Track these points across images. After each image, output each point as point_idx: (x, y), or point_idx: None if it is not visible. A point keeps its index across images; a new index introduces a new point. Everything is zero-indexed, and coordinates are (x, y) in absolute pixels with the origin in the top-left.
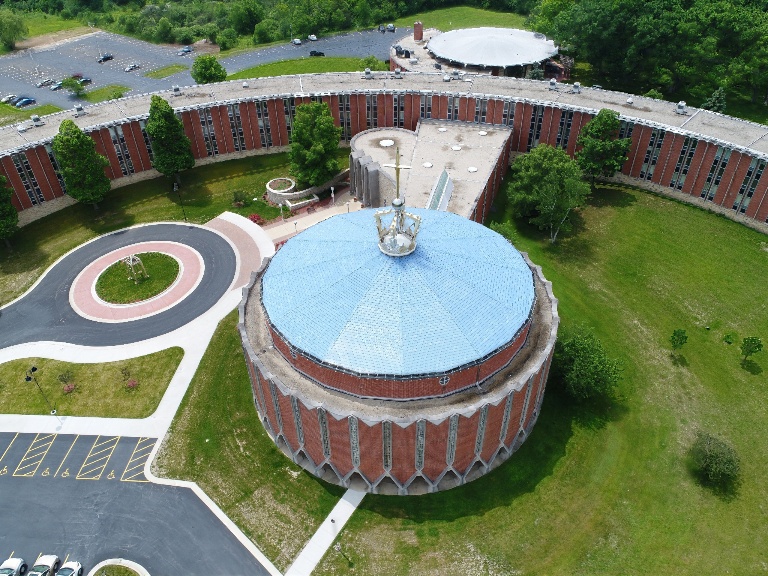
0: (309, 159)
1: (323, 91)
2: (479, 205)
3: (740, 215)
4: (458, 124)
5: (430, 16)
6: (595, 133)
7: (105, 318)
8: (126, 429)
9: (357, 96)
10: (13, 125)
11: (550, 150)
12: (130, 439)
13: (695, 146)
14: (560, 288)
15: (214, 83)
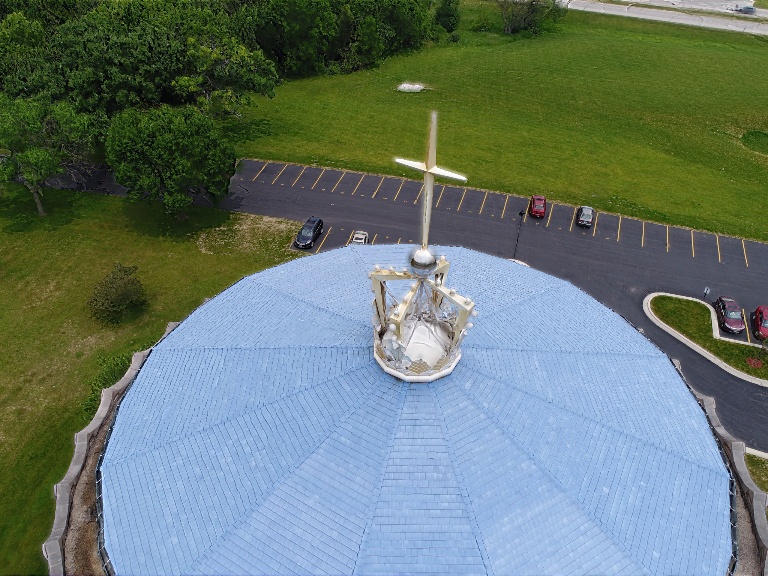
0: None
1: None
2: None
3: None
4: None
5: None
6: None
7: None
8: None
9: None
10: None
11: None
12: None
13: None
14: None
15: None
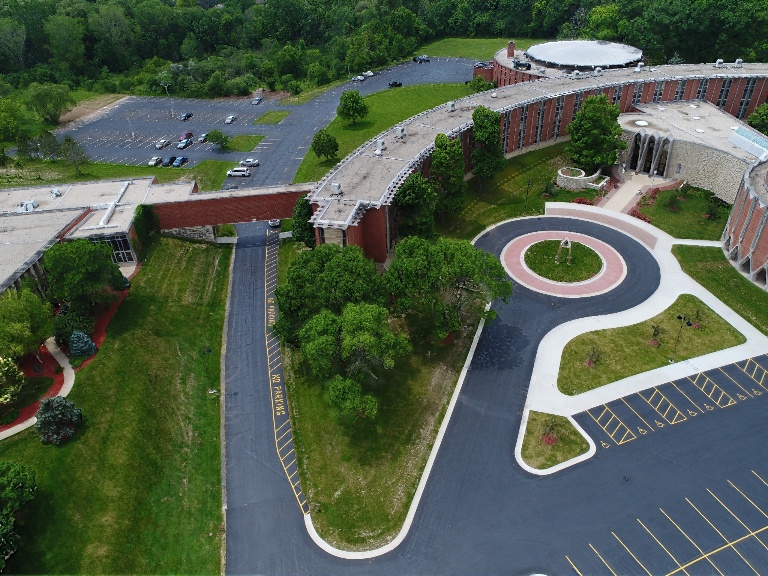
0: (607, 143)
1: (566, 91)
2: None
3: None
4: (663, 104)
5: (438, 47)
6: None
7: (588, 293)
8: (746, 353)
9: (590, 92)
10: (359, 153)
11: None
12: (760, 357)
13: None
14: None
15: (464, 98)
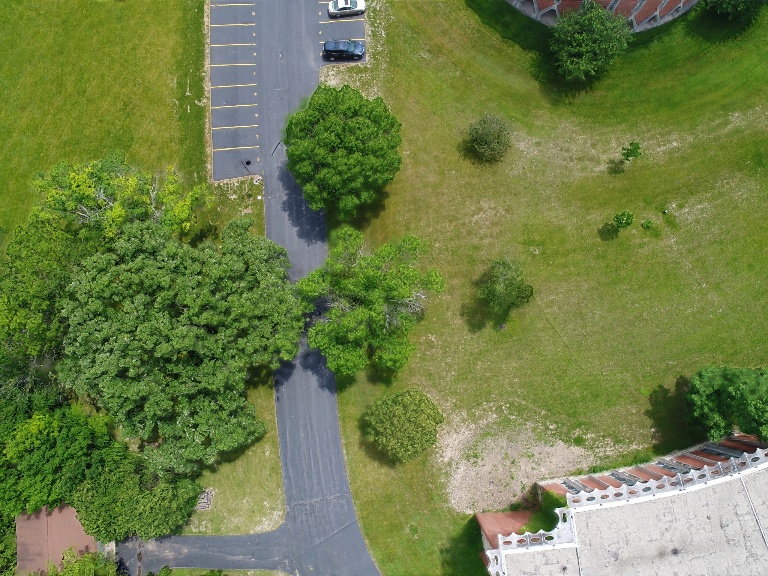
0: None
1: None
2: None
3: None
4: None
5: None
6: None
7: None
8: None
9: None
10: None
11: None
12: None
13: None
14: (734, 82)
15: None
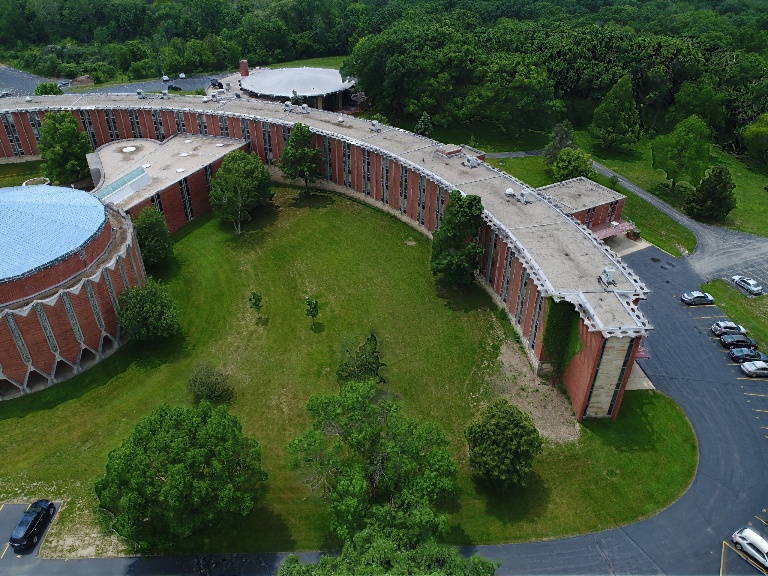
0: None
1: (89, 106)
2: (168, 198)
3: (404, 216)
4: (207, 138)
5: (304, 62)
6: (290, 143)
7: None
8: None
9: (119, 111)
10: None
11: (237, 154)
12: None
13: (369, 156)
14: (216, 268)
15: None
